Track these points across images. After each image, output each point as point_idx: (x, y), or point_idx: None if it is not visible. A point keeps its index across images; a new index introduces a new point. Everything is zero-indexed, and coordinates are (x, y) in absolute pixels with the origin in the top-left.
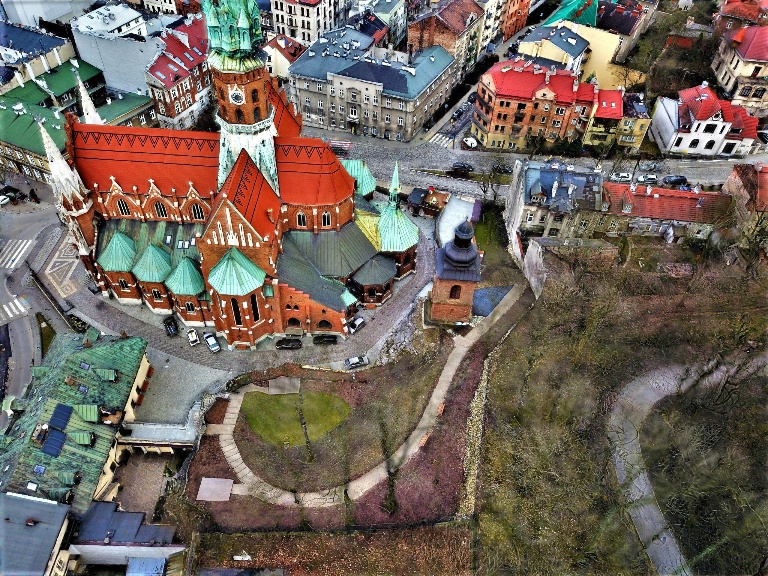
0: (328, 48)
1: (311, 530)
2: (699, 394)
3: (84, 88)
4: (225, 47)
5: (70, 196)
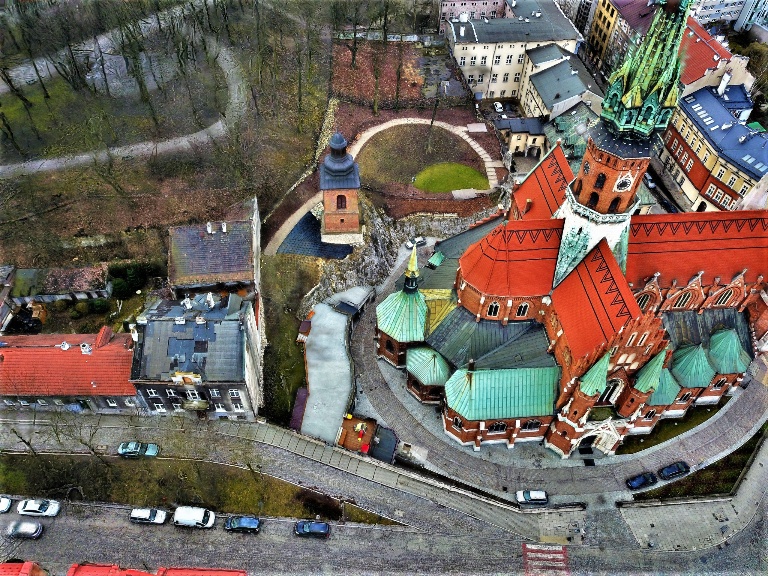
0: None
1: (416, 108)
2: None
3: None
4: None
5: None
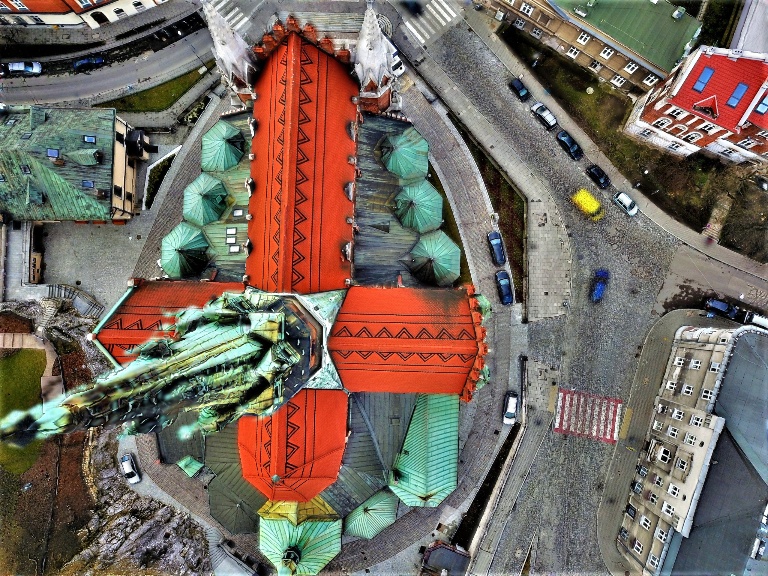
0: None
1: None
2: None
3: (370, 20)
4: None
5: None
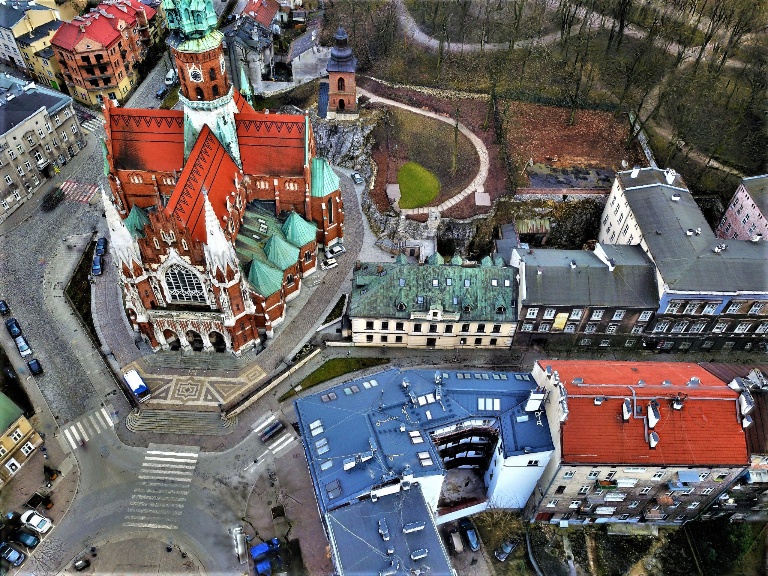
0: None
1: None
2: (440, 7)
3: None
4: (212, 22)
5: (235, 255)
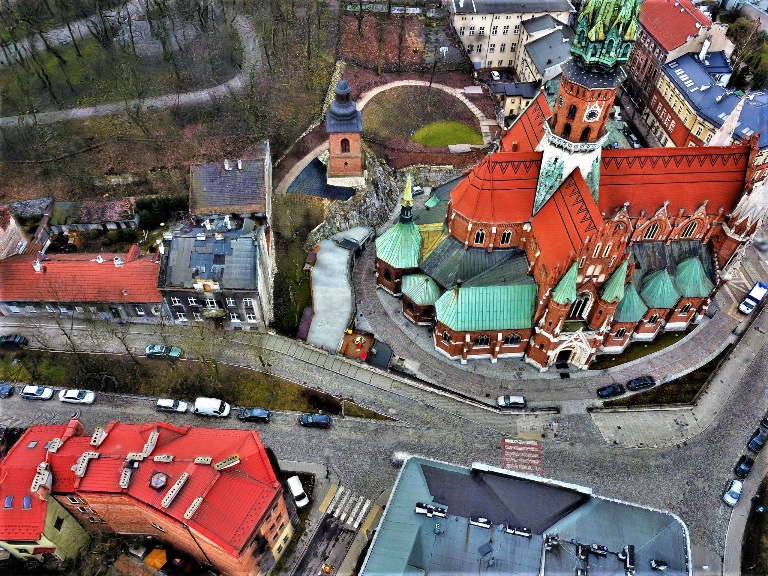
0: (631, 572)
1: (417, 71)
2: None
3: None
4: None
5: None
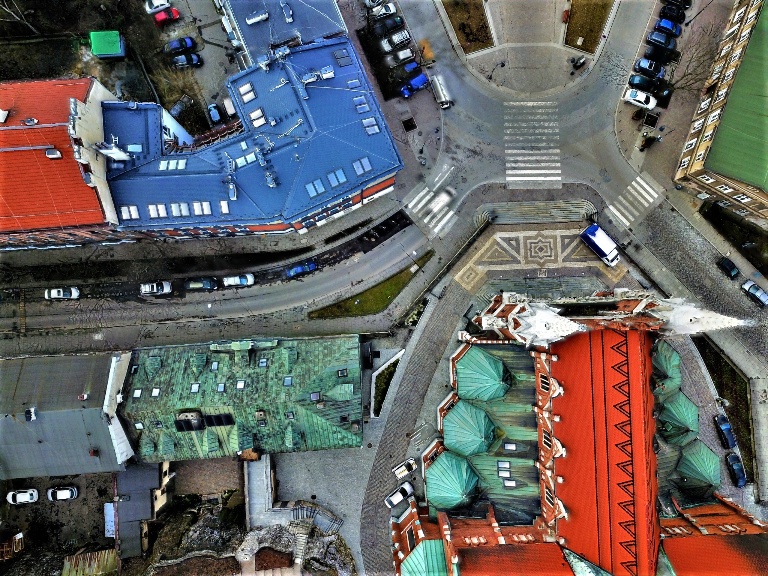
0: None
1: None
2: None
3: None
4: None
5: None
